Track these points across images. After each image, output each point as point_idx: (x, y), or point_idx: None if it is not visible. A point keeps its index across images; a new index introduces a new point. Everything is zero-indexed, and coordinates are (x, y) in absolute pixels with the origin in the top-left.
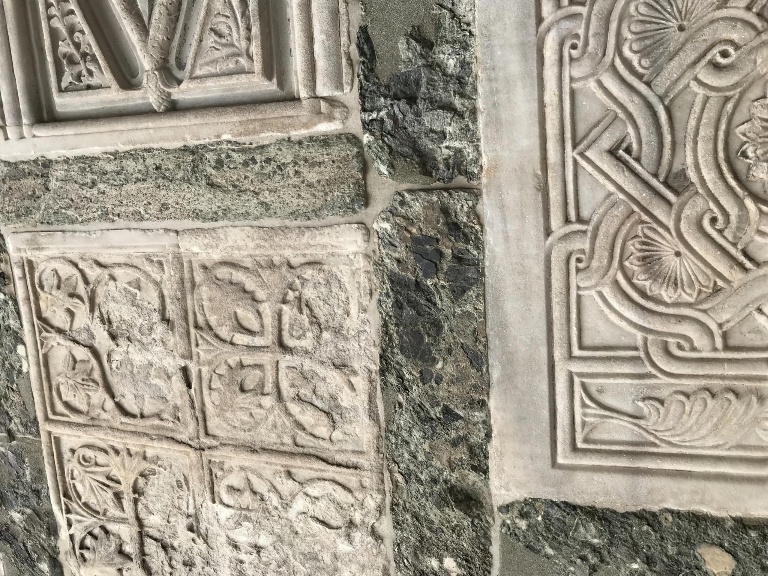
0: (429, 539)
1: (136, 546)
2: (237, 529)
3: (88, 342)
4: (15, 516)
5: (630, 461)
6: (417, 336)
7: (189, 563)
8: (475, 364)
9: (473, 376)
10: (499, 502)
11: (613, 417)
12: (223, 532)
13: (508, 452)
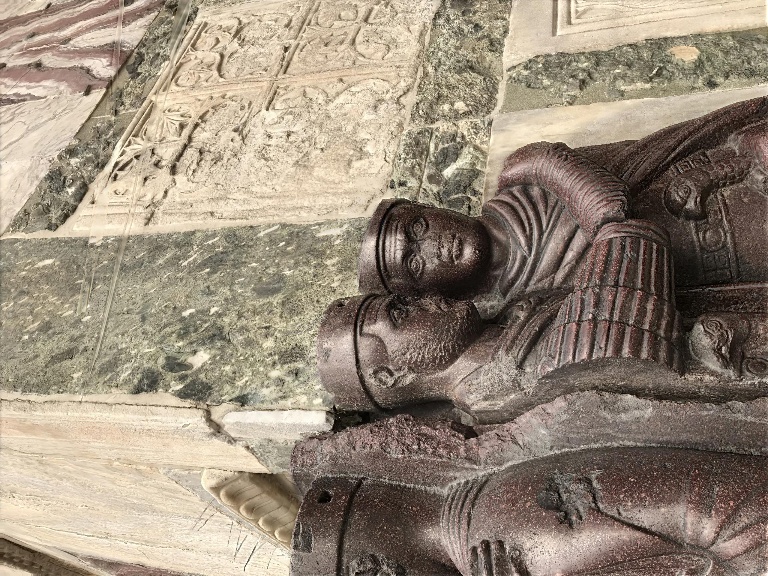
0: (445, 97)
1: (175, 155)
2: (277, 125)
3: (220, 52)
4: (74, 161)
5: (611, 21)
6: (464, 2)
7: (217, 159)
8: (502, 3)
9: (500, 8)
10: (508, 66)
11: (598, 4)
12: (263, 129)
13: (520, 36)
